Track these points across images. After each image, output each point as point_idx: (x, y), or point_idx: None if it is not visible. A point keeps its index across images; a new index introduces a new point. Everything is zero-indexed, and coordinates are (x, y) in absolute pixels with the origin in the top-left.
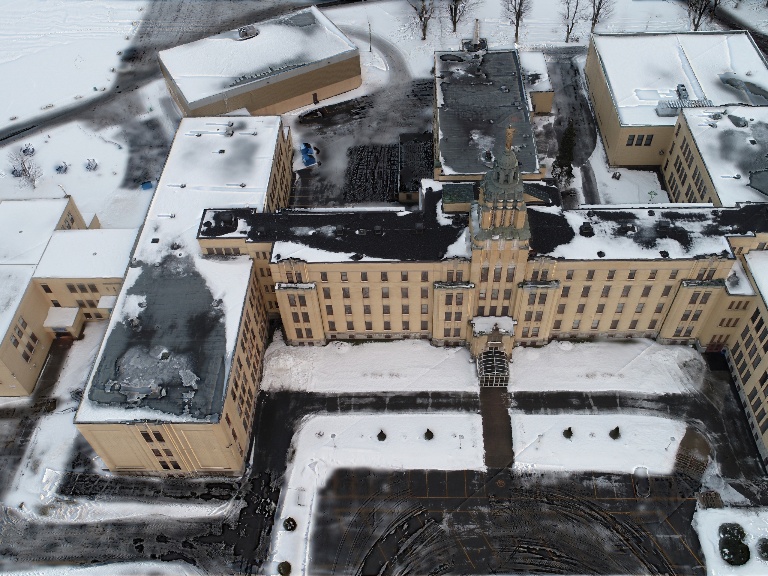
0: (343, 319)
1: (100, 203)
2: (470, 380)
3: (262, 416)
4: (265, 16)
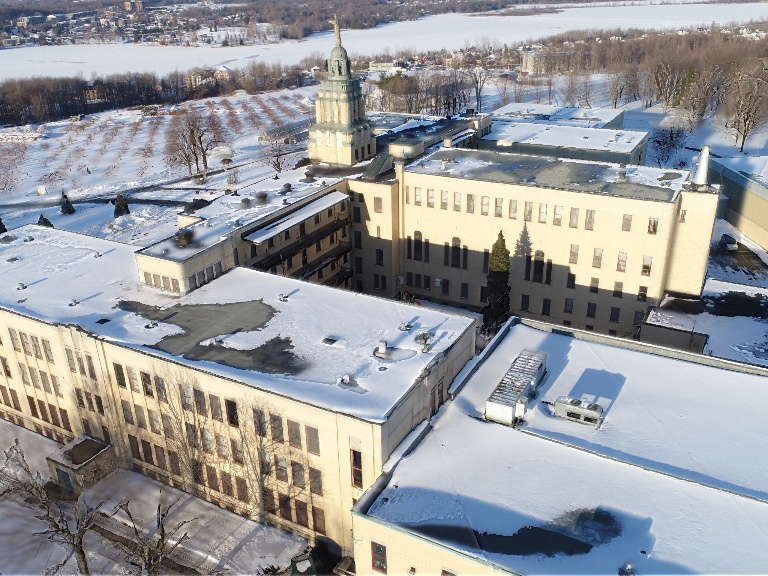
0: None
1: None
2: None
3: None
4: None
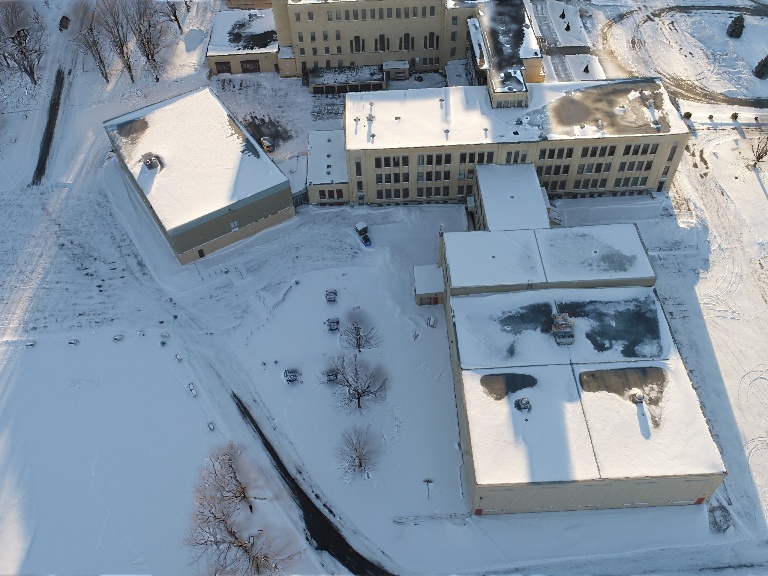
0: None
1: (387, 280)
2: (543, 58)
3: None
4: (38, 209)
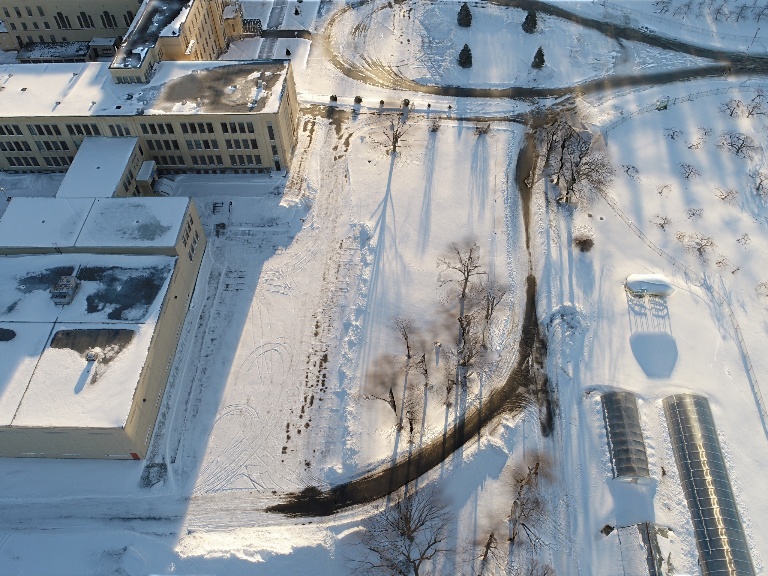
0: None
1: None
2: (255, 40)
3: None
4: None
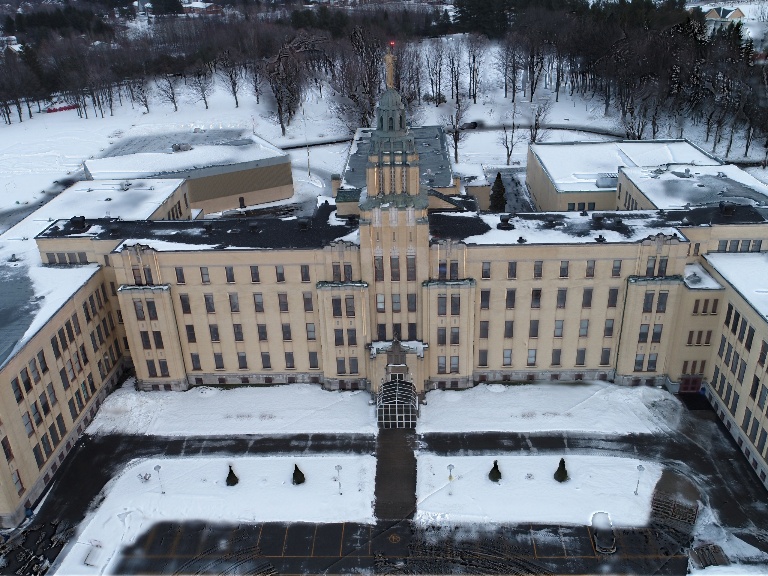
0: (209, 349)
1: None
2: (367, 421)
3: (74, 460)
4: None
